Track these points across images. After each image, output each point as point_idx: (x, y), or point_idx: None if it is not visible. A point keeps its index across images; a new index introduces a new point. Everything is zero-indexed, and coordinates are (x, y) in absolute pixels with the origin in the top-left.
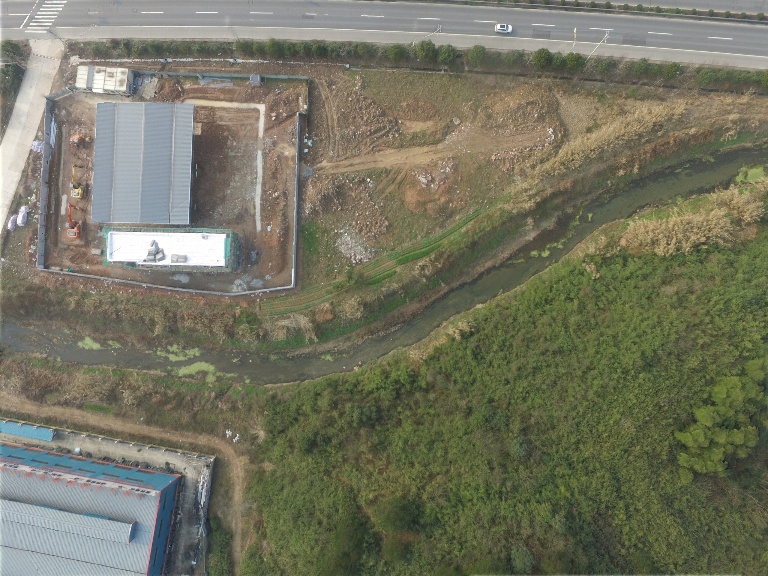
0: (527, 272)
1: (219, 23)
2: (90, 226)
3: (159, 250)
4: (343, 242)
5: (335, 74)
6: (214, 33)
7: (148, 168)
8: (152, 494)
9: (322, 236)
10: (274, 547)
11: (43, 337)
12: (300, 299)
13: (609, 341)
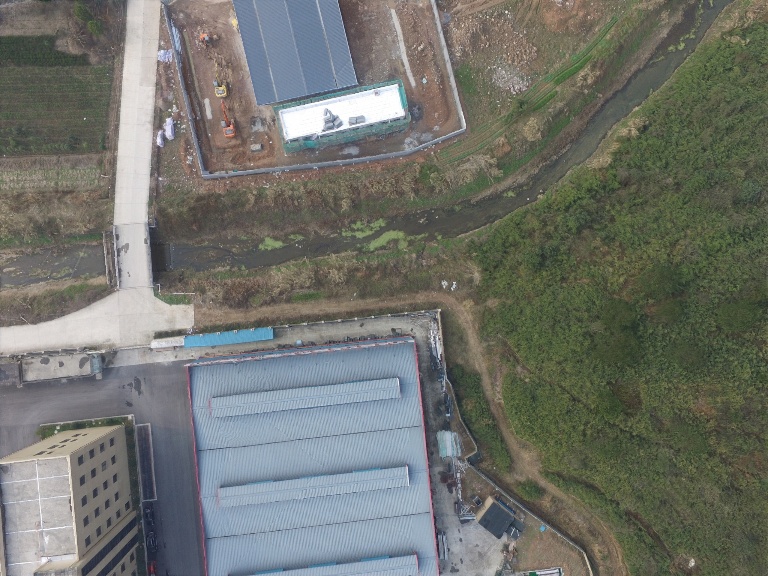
0: (669, 67)
1: None
2: (242, 124)
3: (335, 117)
4: (499, 77)
5: None
6: None
7: (301, 39)
8: (411, 341)
9: (477, 76)
10: (534, 364)
11: (220, 250)
12: (474, 140)
13: None
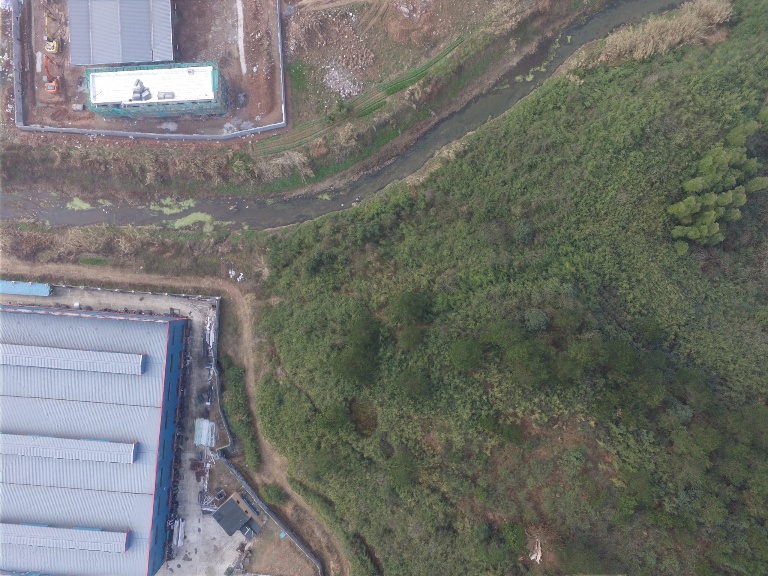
0: (513, 97)
1: None
2: (69, 82)
3: (144, 88)
4: (331, 77)
5: None
6: None
7: (126, 6)
8: (160, 321)
9: (309, 73)
10: (289, 368)
11: (29, 202)
12: (292, 137)
13: (599, 126)
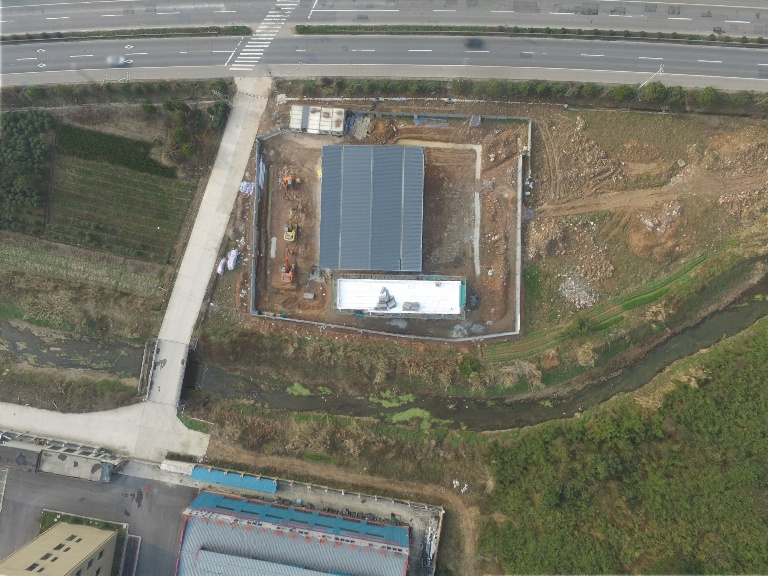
0: (751, 316)
1: (433, 61)
2: (301, 269)
3: (390, 298)
4: (567, 287)
5: (555, 114)
6: (428, 72)
7: (378, 213)
8: (405, 552)
9: (544, 280)
10: None
11: (250, 383)
12: (524, 345)
13: None
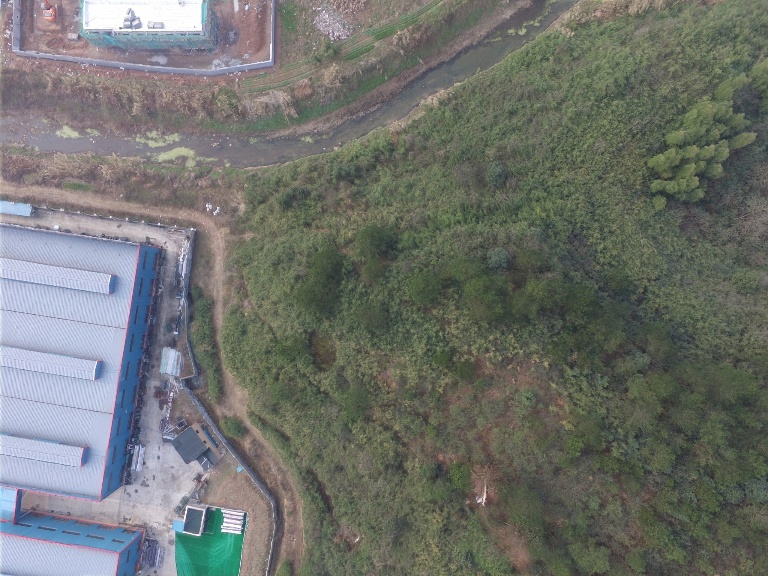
0: (504, 50)
1: None
2: (66, 11)
3: (135, 17)
4: (321, 19)
5: None
6: None
7: None
8: None
9: (300, 14)
10: (255, 300)
11: (20, 127)
12: (279, 76)
13: (583, 74)
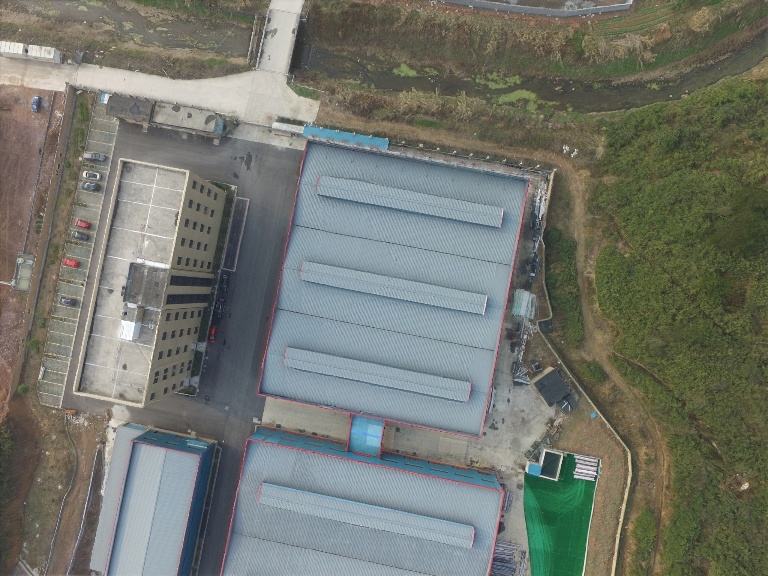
0: None
1: None
2: None
3: None
4: None
5: None
6: None
7: None
8: None
9: None
10: (640, 240)
11: (356, 64)
12: (635, 20)
13: None
